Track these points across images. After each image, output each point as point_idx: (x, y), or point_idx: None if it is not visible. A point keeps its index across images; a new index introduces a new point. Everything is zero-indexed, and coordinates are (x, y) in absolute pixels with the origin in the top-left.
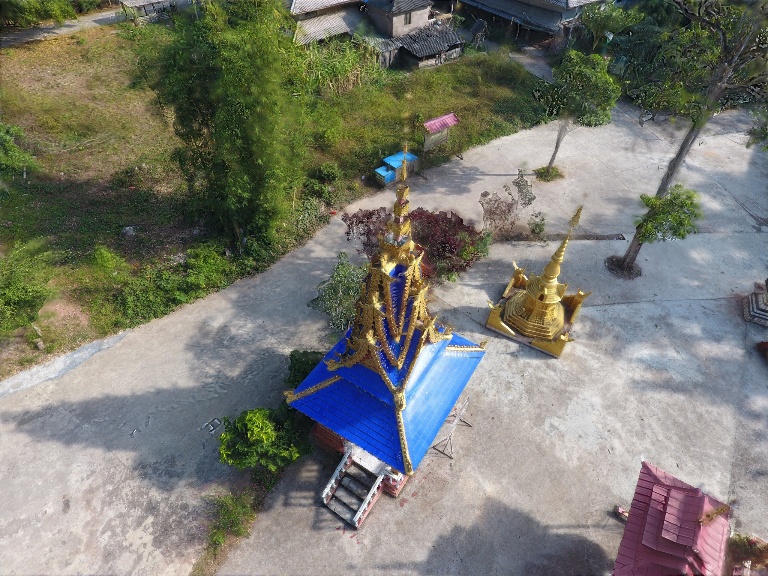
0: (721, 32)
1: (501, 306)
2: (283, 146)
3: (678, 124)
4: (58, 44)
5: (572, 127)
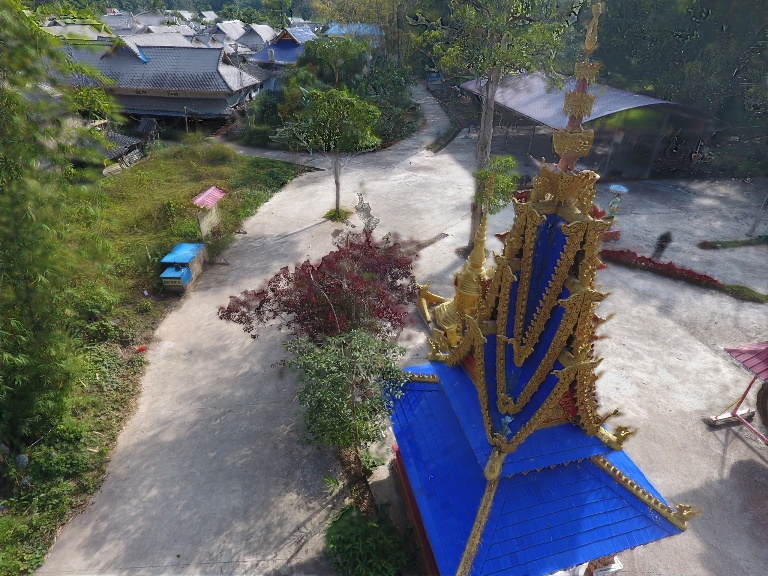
0: (485, 10)
1: None
2: (75, 238)
3: (383, 156)
4: None
5: (345, 160)
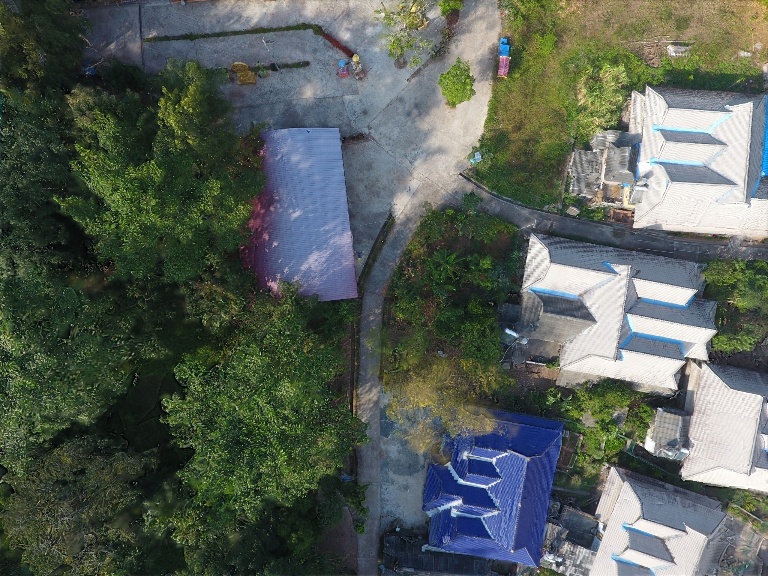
0: None
1: (423, 14)
2: None
3: None
4: (760, 8)
5: None
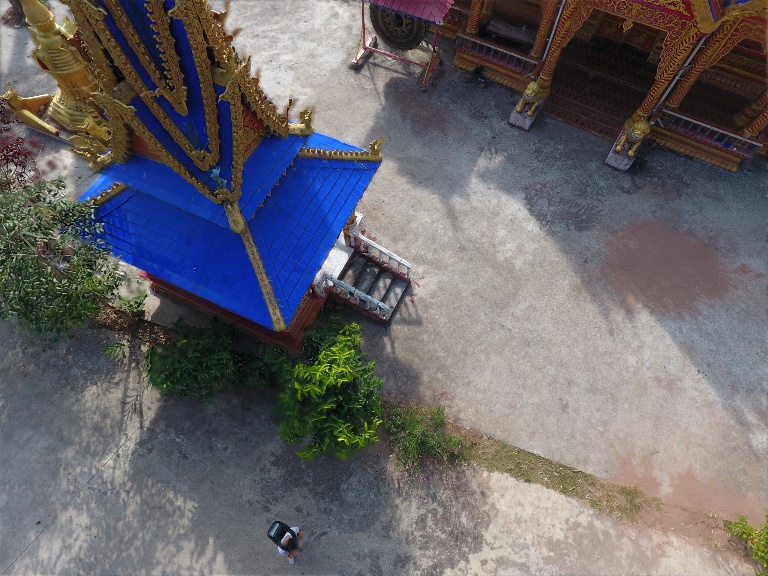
0: None
1: None
2: None
3: None
4: None
5: None
